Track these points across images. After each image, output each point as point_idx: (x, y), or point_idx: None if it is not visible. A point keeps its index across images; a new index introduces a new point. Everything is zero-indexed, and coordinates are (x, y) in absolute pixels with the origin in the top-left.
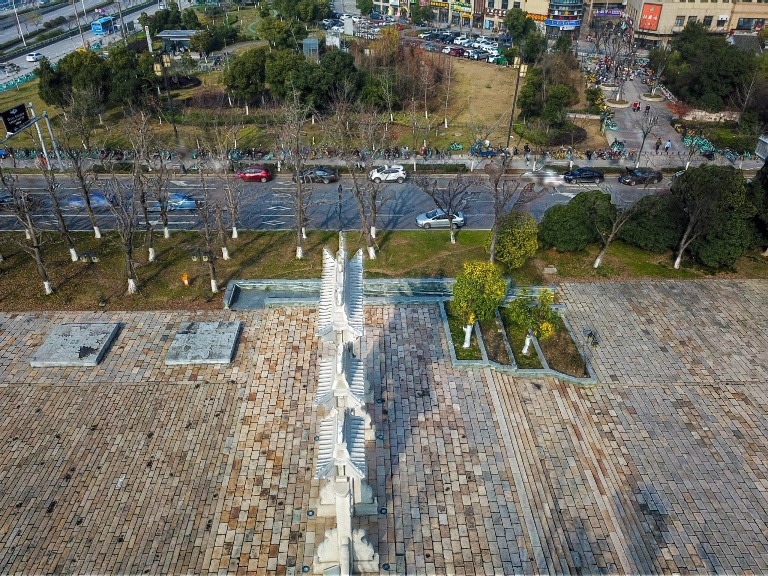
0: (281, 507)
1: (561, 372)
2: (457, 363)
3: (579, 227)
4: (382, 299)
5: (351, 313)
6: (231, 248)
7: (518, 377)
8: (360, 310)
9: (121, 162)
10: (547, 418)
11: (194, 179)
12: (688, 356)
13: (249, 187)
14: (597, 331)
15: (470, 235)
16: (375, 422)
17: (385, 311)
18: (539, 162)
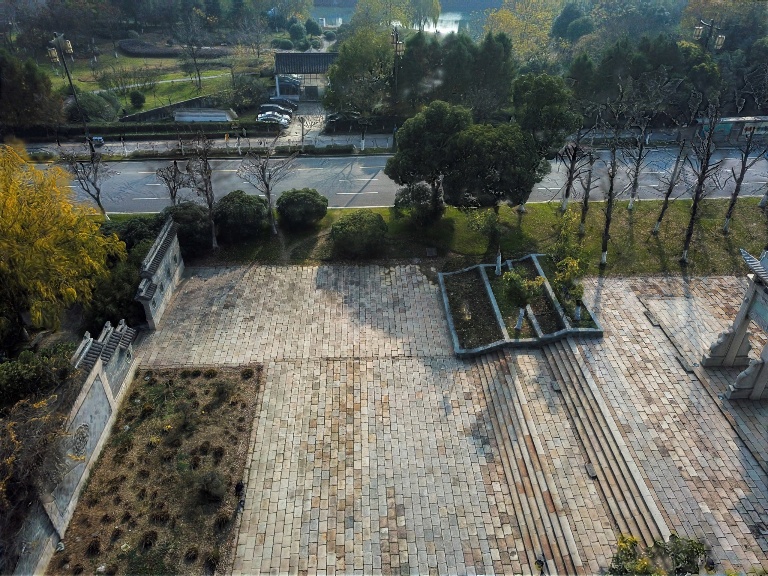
0: None
1: None
2: (738, 573)
3: None
4: None
5: None
6: None
7: None
8: None
9: None
10: (586, 517)
11: None
12: None
13: None
14: None
15: None
16: None
17: None
18: None
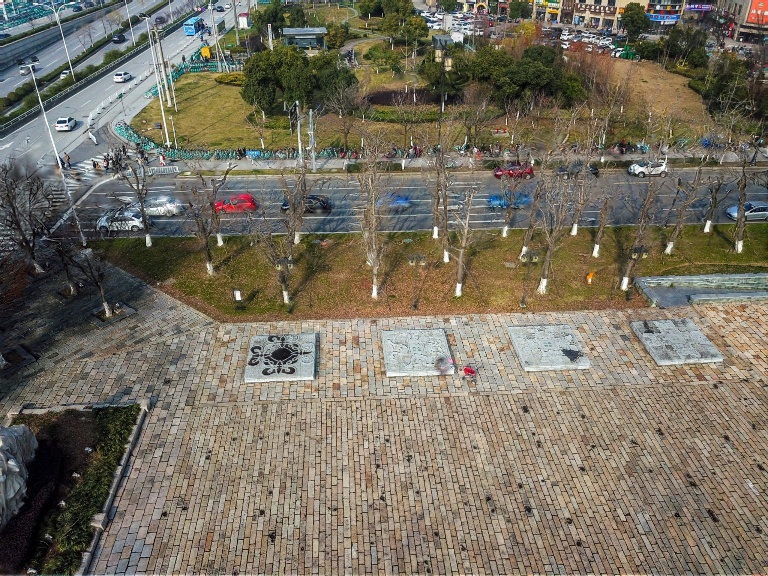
0: None
1: None
2: None
3: None
4: None
5: None
6: (584, 245)
7: None
8: None
9: None
10: None
11: None
12: None
13: None
14: None
15: None
16: None
17: None
18: None
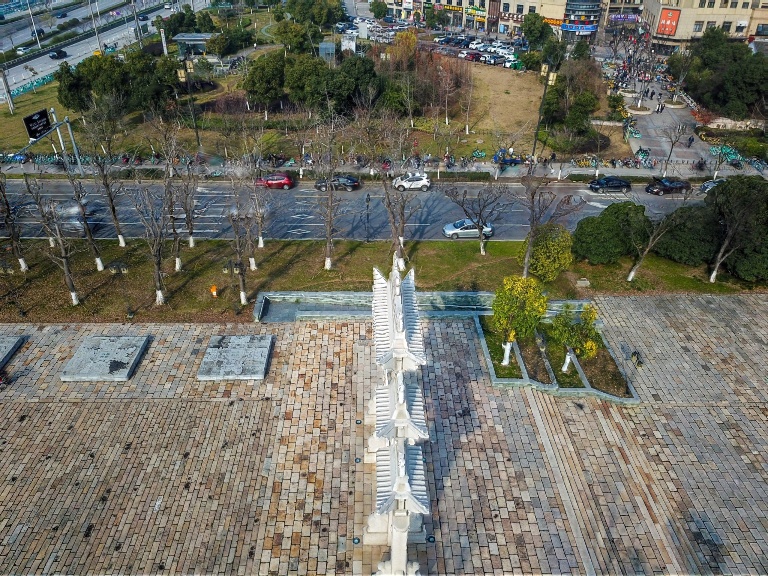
0: (325, 534)
1: (603, 391)
2: (497, 382)
3: (613, 239)
4: None
5: (410, 339)
6: (258, 258)
7: (559, 396)
8: (419, 335)
9: (141, 168)
10: (592, 440)
11: (216, 186)
12: (731, 375)
13: (272, 194)
14: (635, 348)
15: (499, 246)
16: (417, 443)
17: None
18: (564, 170)
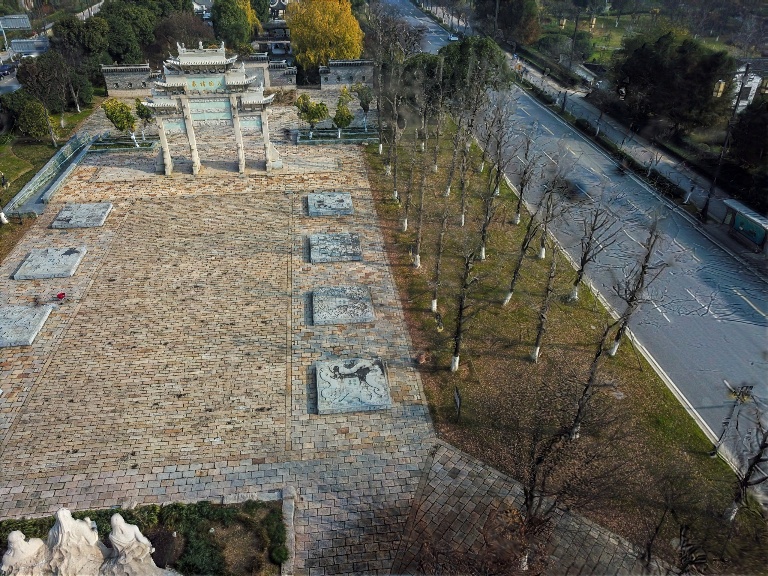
0: (236, 181)
1: None
2: None
3: None
4: (74, 164)
5: None
6: None
7: None
8: None
9: None
10: None
11: None
12: None
13: None
14: None
15: None
16: None
17: (84, 167)
18: None
